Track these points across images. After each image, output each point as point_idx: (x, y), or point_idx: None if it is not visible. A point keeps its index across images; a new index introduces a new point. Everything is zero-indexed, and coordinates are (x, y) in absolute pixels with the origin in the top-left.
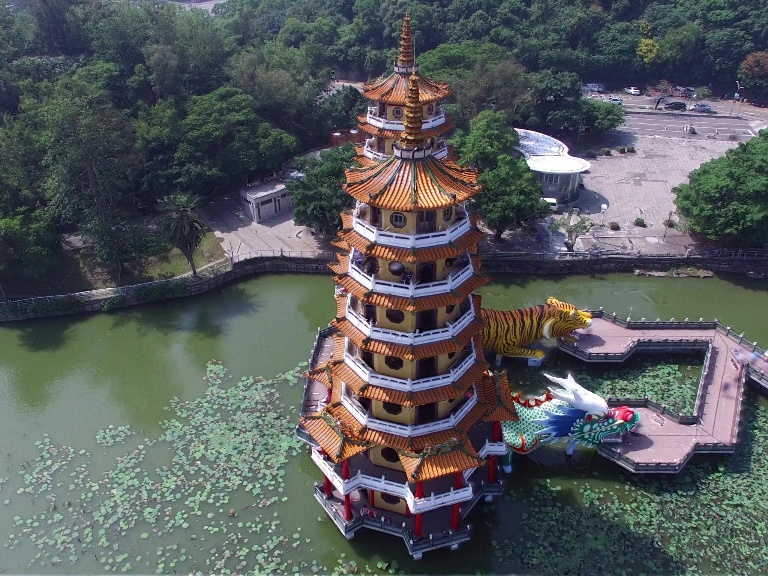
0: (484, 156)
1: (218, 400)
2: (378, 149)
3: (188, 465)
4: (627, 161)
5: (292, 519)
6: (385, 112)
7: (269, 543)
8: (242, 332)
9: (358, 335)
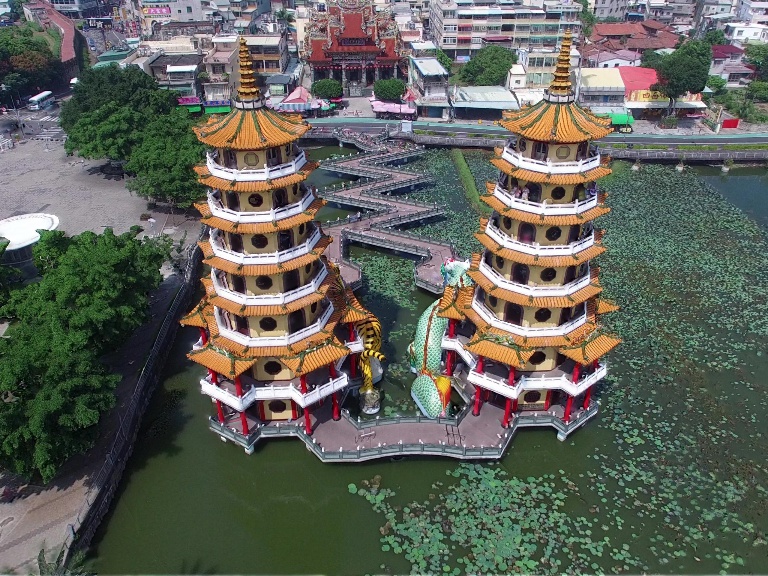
0: (0, 257)
1: (434, 569)
2: (277, 206)
3: (551, 570)
4: None
5: (581, 463)
6: (271, 158)
7: (613, 475)
8: None
9: (589, 252)
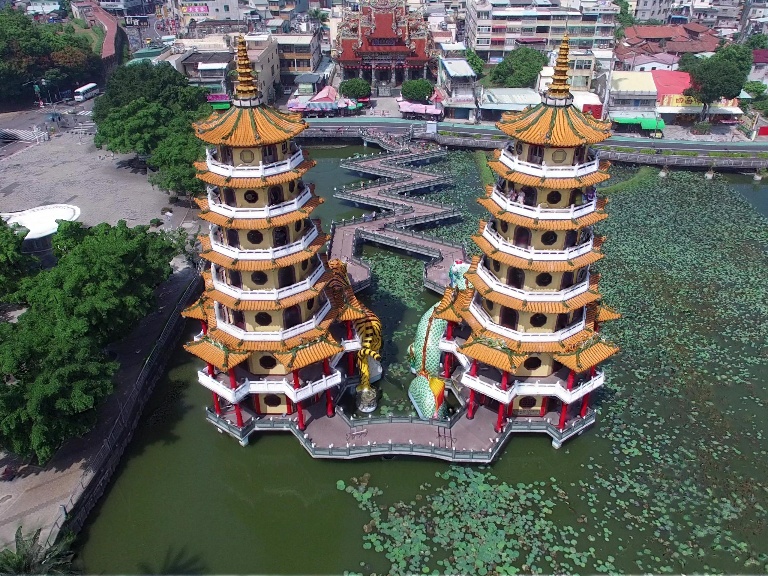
0: (19, 245)
1: (413, 569)
2: (272, 203)
3: None
4: (5, 204)
5: (574, 472)
6: (267, 156)
7: (605, 485)
8: (246, 574)
9: (586, 258)
